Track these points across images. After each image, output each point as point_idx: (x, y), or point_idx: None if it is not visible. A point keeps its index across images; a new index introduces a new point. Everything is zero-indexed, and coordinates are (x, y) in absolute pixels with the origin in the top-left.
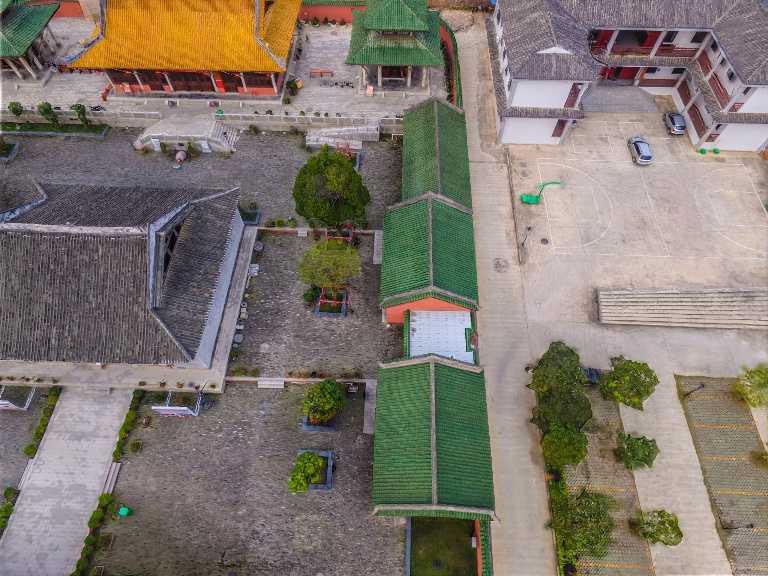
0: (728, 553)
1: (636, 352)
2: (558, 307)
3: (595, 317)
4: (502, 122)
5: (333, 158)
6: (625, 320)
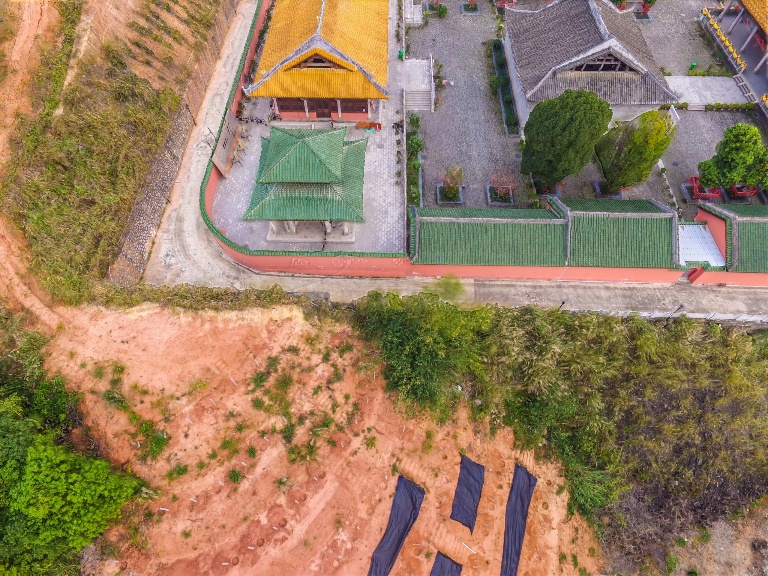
0: None
1: None
2: None
3: None
4: None
5: None
6: None
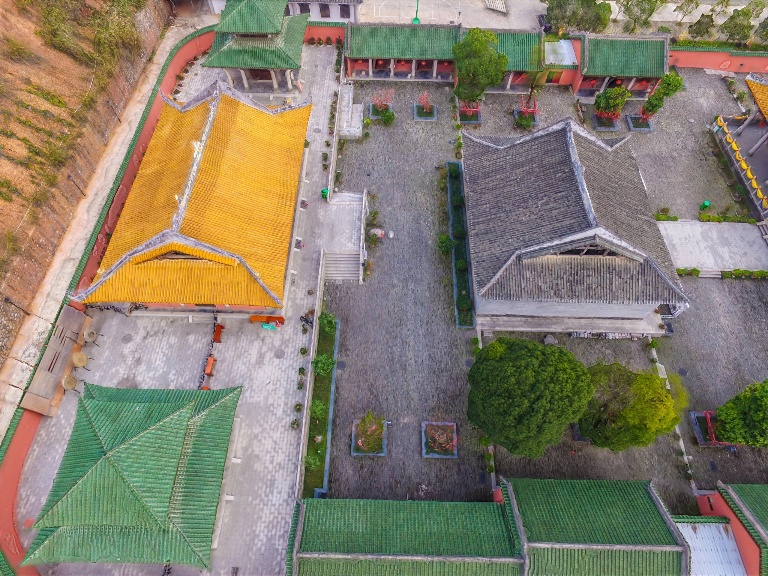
0: (614, 0)
1: (522, 5)
2: (501, 25)
3: (503, 14)
4: (356, 11)
5: (479, 30)
6: (502, 5)
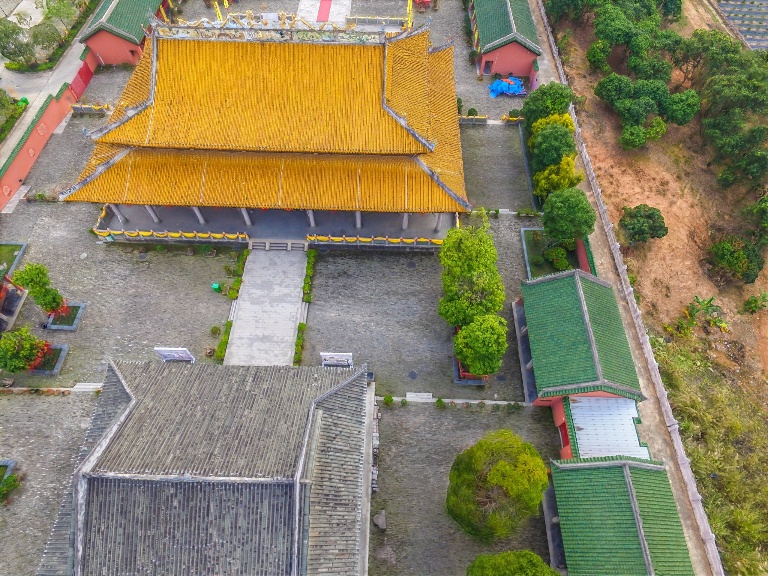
0: None
1: None
2: None
3: None
4: None
5: None
6: None
